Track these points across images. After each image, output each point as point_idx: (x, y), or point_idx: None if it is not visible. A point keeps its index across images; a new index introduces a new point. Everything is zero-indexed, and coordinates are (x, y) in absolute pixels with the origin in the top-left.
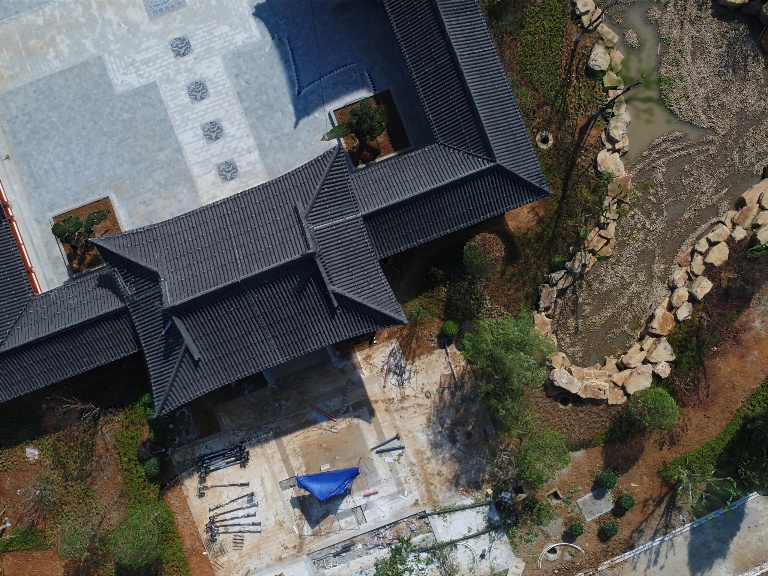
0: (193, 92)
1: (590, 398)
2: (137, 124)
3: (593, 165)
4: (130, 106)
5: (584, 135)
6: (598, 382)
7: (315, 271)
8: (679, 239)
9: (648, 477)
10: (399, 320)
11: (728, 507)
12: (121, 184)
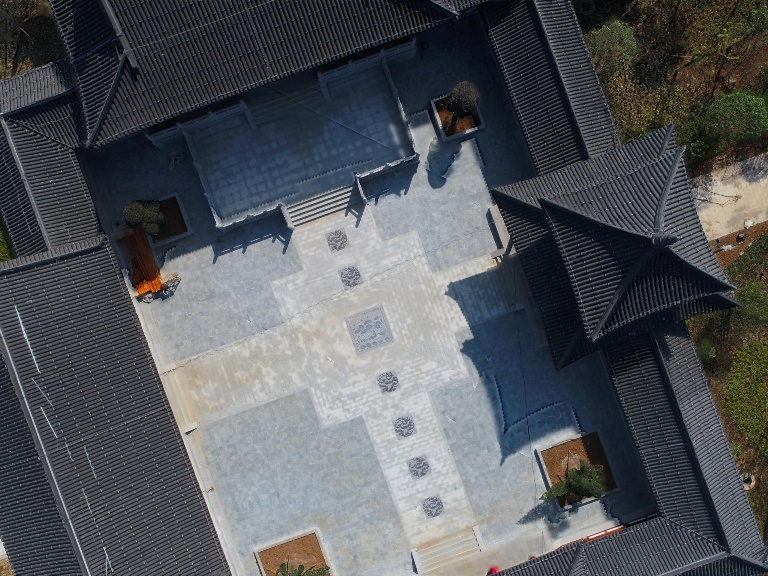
0: (400, 428)
1: None
2: (343, 458)
3: None
4: (336, 440)
5: None
6: None
7: None
8: None
9: None
10: None
11: None
12: (326, 518)
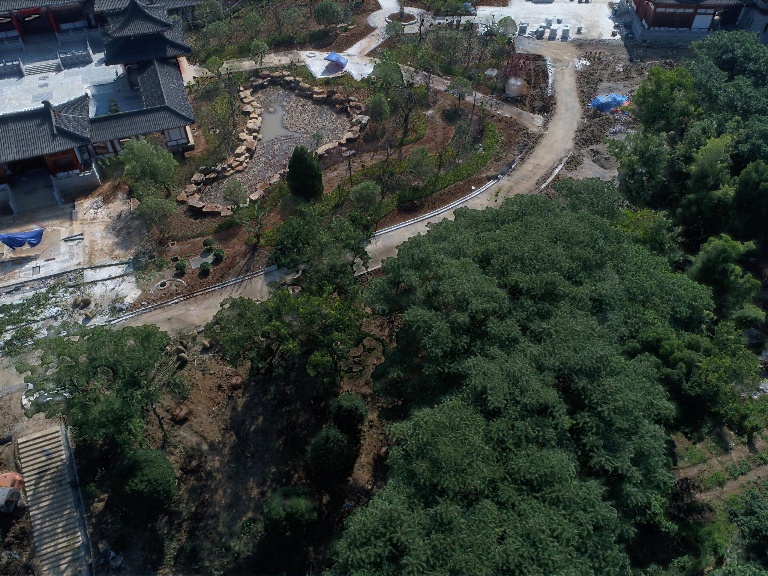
0: None
1: (211, 214)
2: None
3: (237, 138)
4: None
5: None
6: None
7: (50, 119)
8: None
9: (238, 246)
10: (86, 137)
11: None
12: None
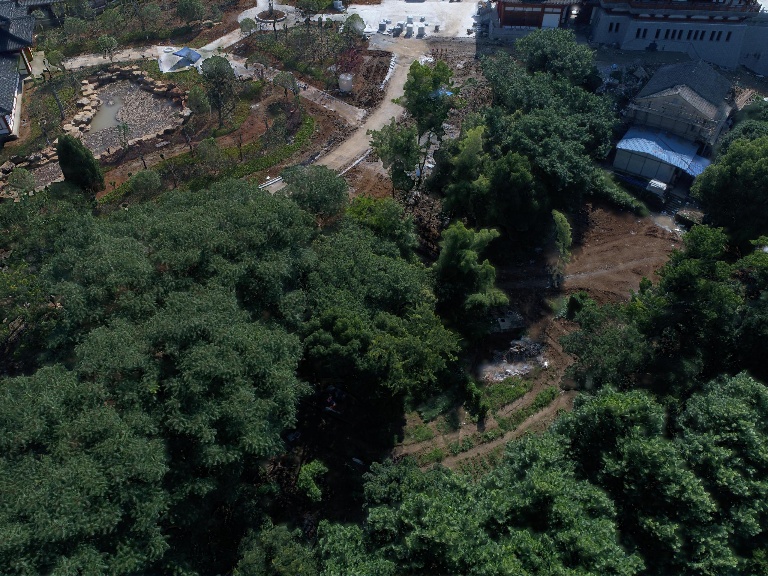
0: None
1: (5, 201)
2: None
3: None
4: None
5: (62, 120)
6: None
7: None
8: None
9: None
10: None
11: None
12: None
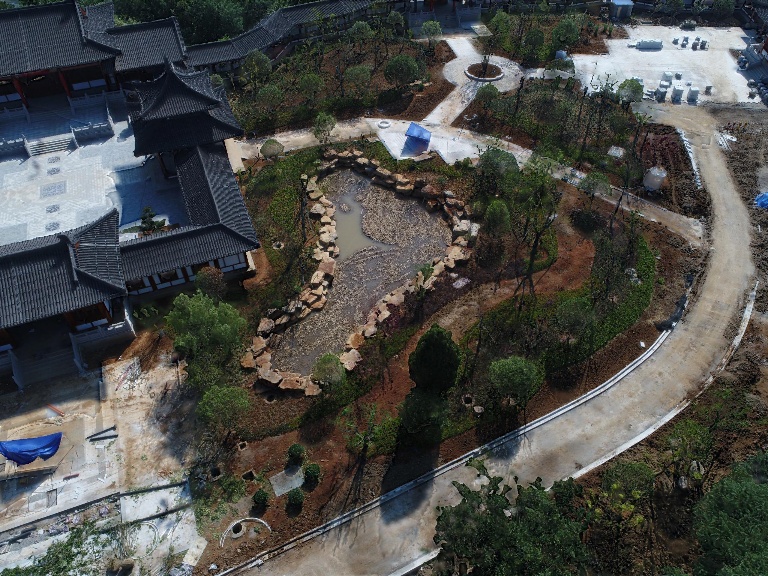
0: (49, 227)
1: (291, 392)
2: (2, 241)
3: (309, 257)
4: (3, 234)
5: (304, 242)
6: (297, 377)
7: (68, 258)
8: (374, 300)
9: (337, 453)
10: (119, 288)
11: (415, 480)
12: None
